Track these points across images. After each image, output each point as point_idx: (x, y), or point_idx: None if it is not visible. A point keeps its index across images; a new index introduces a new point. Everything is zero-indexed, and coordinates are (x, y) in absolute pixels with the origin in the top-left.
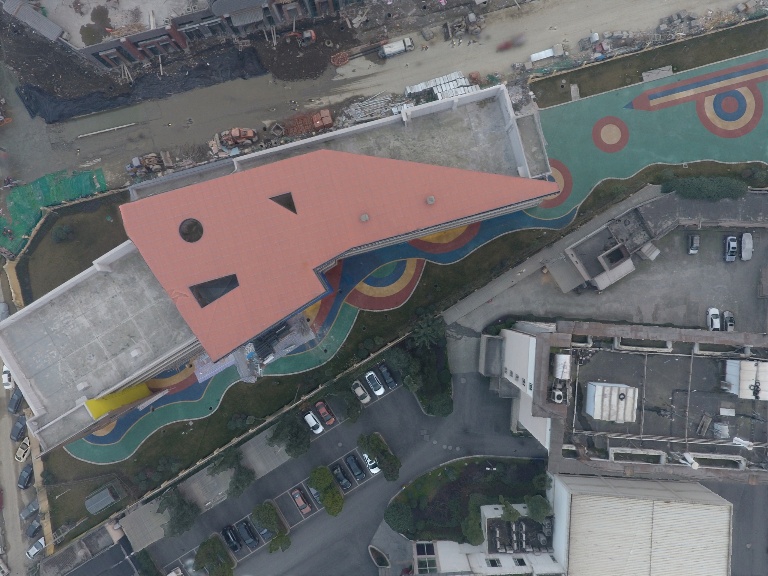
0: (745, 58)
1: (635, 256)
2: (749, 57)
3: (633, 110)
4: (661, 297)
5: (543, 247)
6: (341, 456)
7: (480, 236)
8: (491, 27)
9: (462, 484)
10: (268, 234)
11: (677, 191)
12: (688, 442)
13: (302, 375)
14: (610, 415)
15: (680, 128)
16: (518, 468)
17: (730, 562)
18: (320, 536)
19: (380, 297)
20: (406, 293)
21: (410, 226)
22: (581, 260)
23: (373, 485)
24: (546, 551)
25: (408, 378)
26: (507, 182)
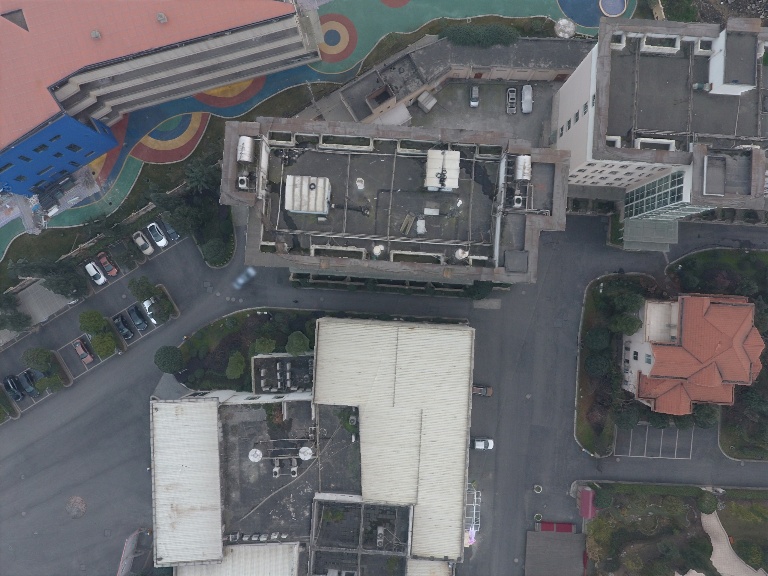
0: None
1: (419, 110)
2: None
3: None
4: None
5: (321, 97)
6: (125, 308)
7: (265, 90)
8: None
9: (242, 334)
10: (1, 52)
11: (448, 37)
12: (390, 240)
13: (86, 227)
14: (301, 205)
15: None
16: (298, 318)
17: (471, 386)
18: (103, 387)
19: (165, 150)
20: (190, 146)
21: (144, 45)
22: (350, 104)
23: (156, 336)
24: (310, 390)
25: (166, 213)
26: (241, 2)
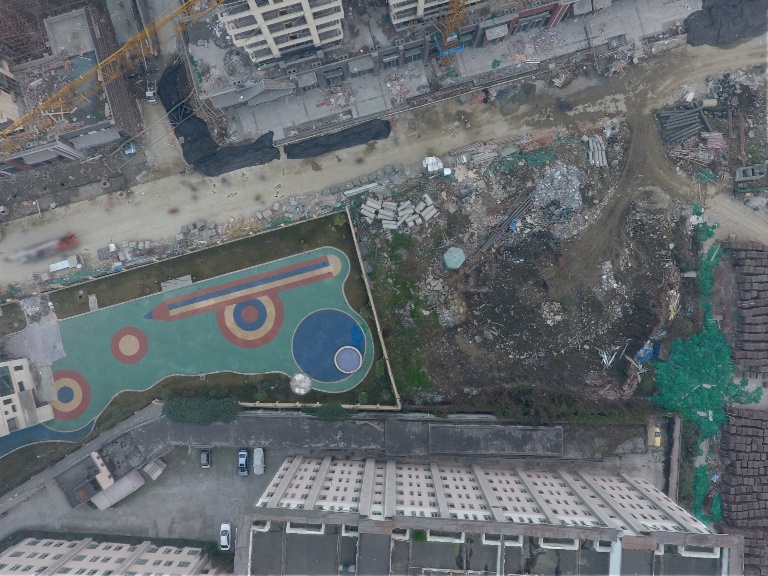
0: (266, 266)
1: None
2: (269, 265)
3: (152, 320)
4: (177, 510)
5: (47, 466)
6: None
7: None
8: (12, 236)
9: None
10: None
11: (166, 416)
12: None
13: None
14: None
15: (200, 338)
16: None
17: None
18: None
19: None
20: None
21: None
22: (64, 488)
23: None
24: None
25: None
26: None
